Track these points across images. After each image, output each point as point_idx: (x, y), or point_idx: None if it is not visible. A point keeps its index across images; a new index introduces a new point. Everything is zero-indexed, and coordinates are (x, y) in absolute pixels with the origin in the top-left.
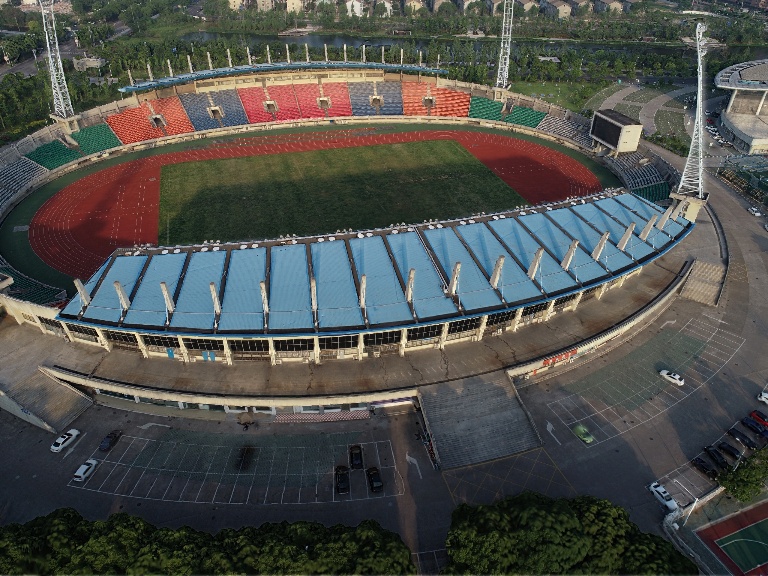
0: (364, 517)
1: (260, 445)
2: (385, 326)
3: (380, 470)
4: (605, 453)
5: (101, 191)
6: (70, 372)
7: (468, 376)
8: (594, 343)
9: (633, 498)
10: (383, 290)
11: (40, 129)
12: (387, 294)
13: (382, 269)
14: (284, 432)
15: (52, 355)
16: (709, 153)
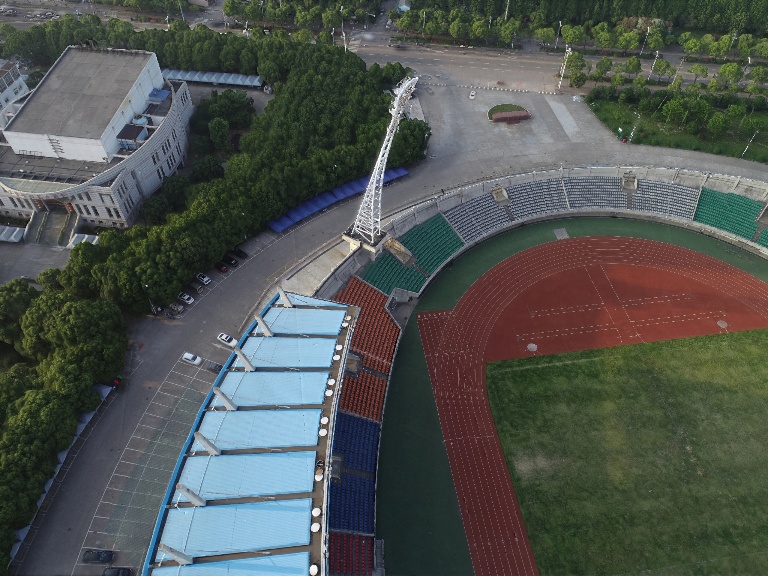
0: (54, 574)
1: None
2: None
3: None
4: None
5: (669, 278)
6: None
7: None
8: None
9: None
10: None
11: None
12: None
13: None
14: None
15: None
16: None
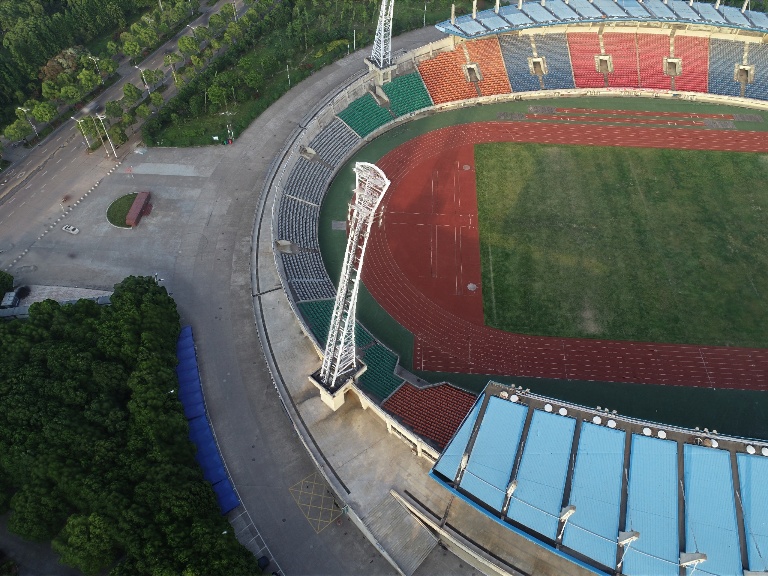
0: None
1: None
2: None
3: None
4: None
5: (413, 177)
6: (422, 508)
7: None
8: None
9: None
10: None
11: (341, 55)
12: None
13: None
14: None
15: (401, 472)
16: None
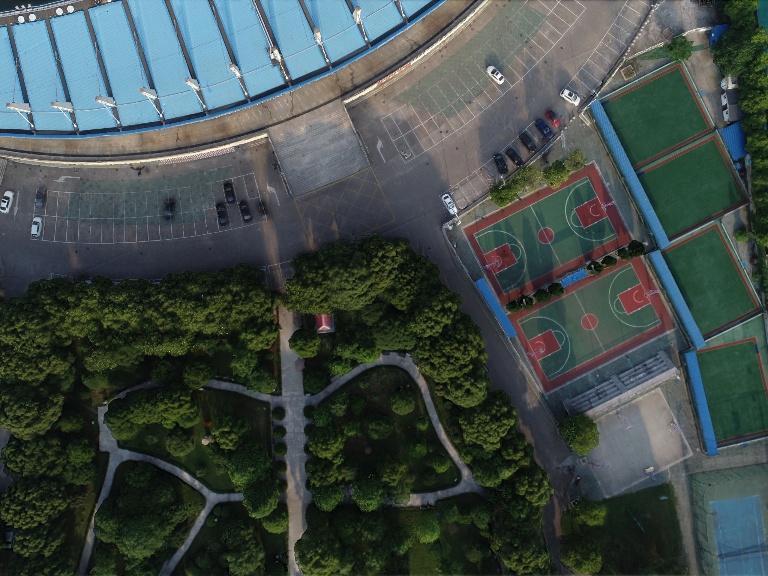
0: (242, 242)
1: (155, 188)
2: (222, 109)
3: (249, 202)
4: (418, 167)
5: None
6: None
7: (310, 110)
8: (429, 50)
9: (428, 207)
10: (213, 63)
11: None
12: (217, 69)
13: (207, 32)
14: (170, 174)
15: None
16: None
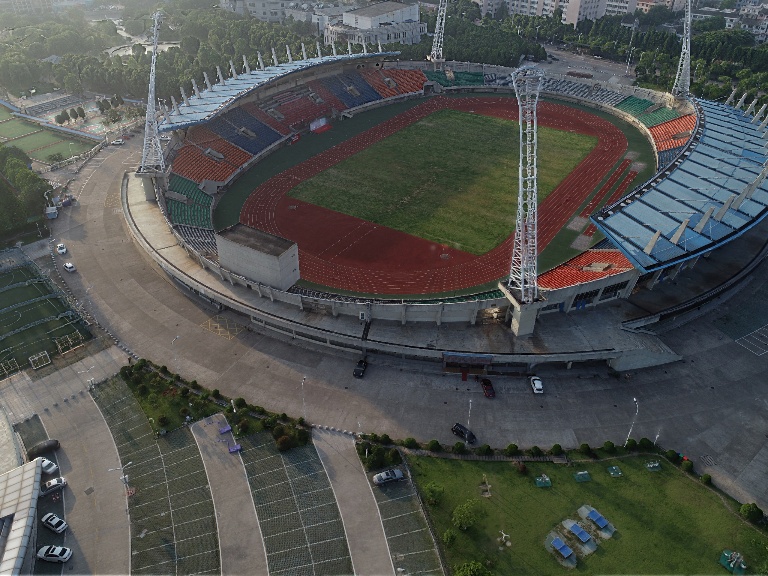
0: None
1: None
2: None
3: None
4: None
5: (571, 118)
6: None
7: None
8: None
9: None
10: None
11: None
12: None
13: None
14: None
15: None
16: (93, 401)
